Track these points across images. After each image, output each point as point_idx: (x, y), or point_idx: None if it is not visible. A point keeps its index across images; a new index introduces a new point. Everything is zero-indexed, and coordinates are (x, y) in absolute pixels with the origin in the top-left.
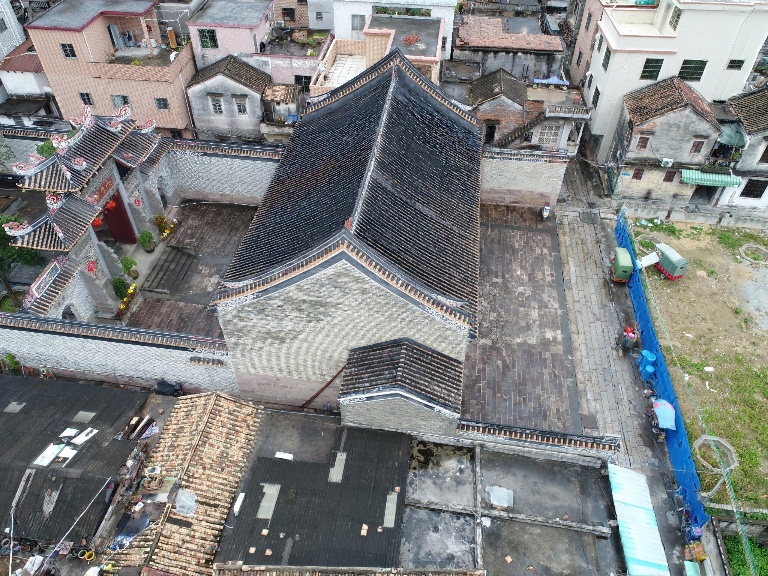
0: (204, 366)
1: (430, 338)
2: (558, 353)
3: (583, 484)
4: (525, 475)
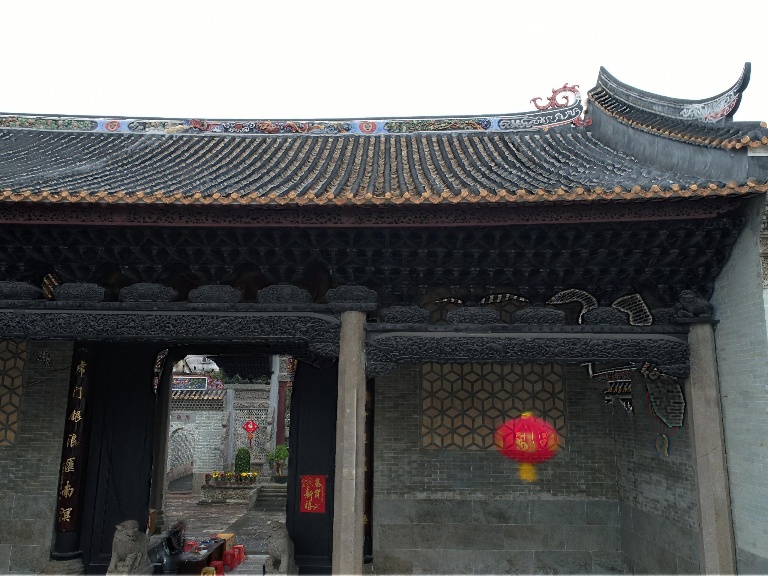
0: None
1: None
2: None
3: None
4: None
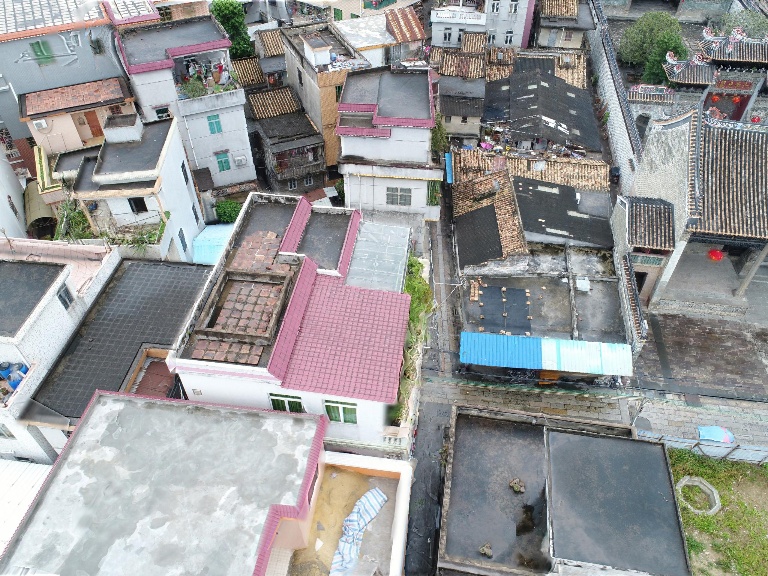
0: (630, 169)
1: (678, 214)
2: (765, 390)
3: (610, 334)
4: (605, 303)
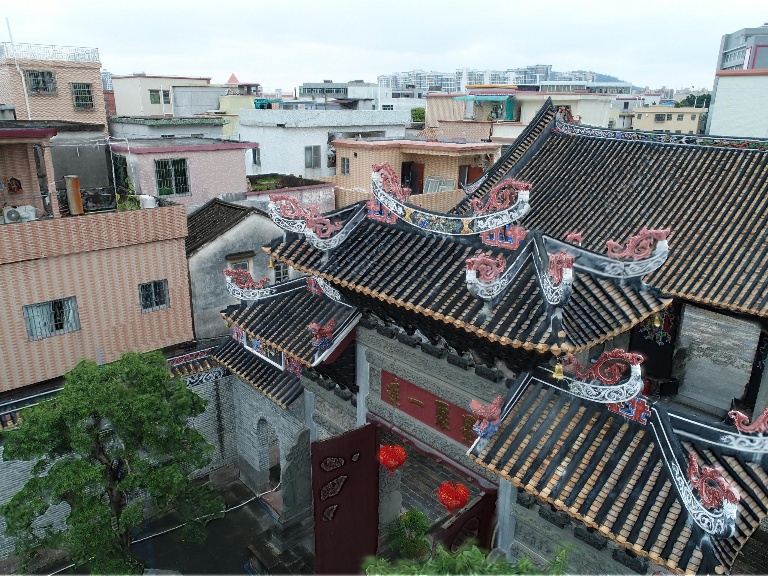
0: None
1: None
2: None
3: None
4: None
